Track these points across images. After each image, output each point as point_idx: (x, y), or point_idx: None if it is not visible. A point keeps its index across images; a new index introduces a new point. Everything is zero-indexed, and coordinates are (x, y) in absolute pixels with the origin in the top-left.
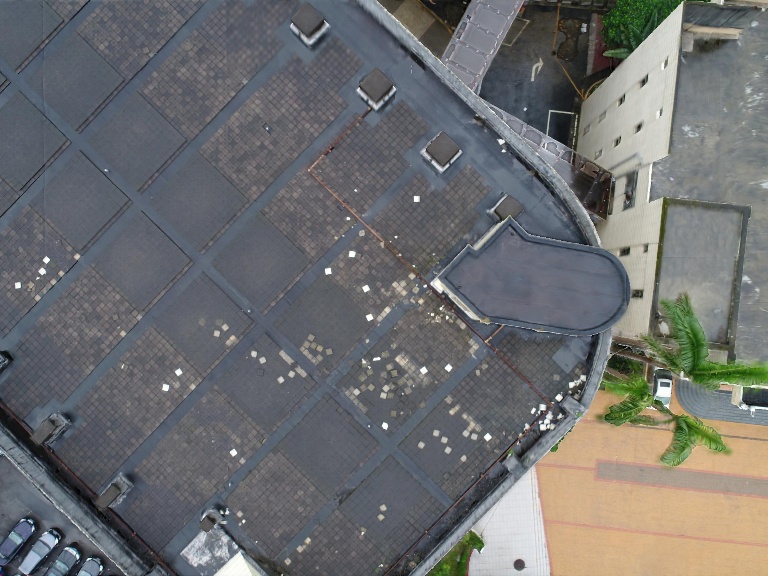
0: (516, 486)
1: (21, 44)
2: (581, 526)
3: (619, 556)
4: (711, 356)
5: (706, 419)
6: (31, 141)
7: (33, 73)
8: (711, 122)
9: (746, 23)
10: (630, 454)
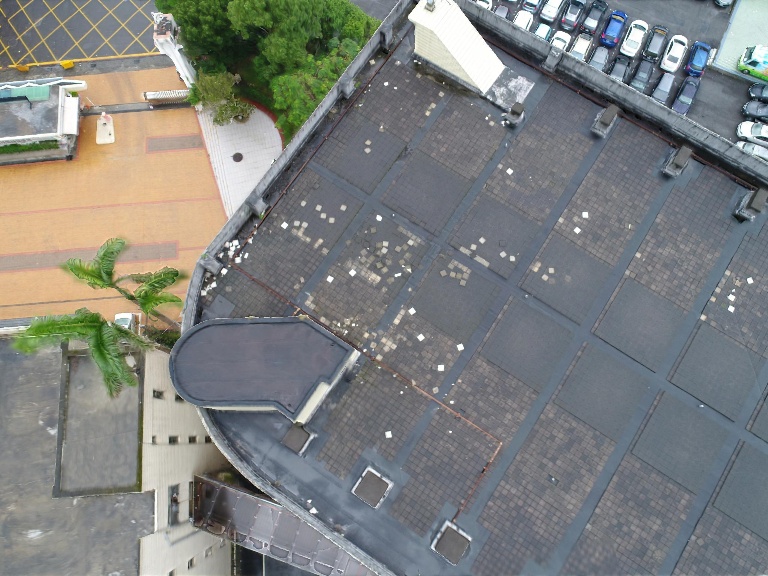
0: None
1: None
2: (187, 200)
3: (150, 181)
4: (83, 346)
5: None
6: None
7: None
8: None
9: None
10: (148, 269)
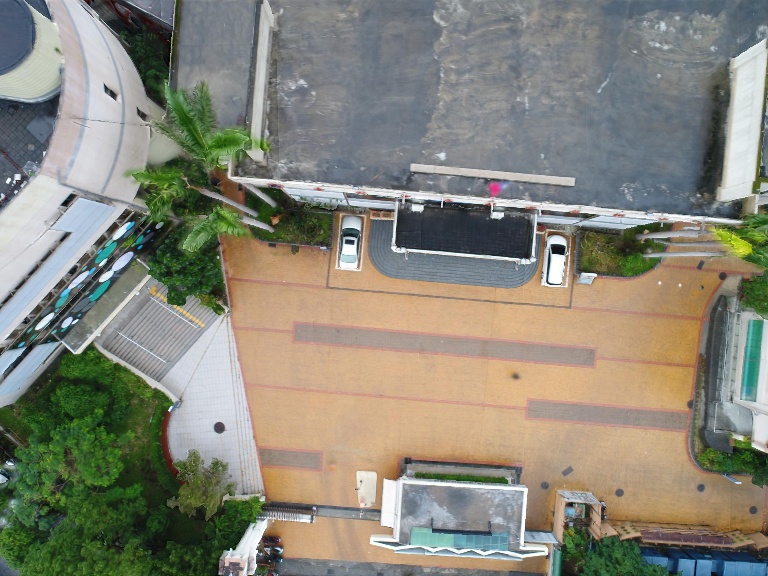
0: (213, 349)
1: None
2: (281, 389)
3: (320, 417)
4: None
5: (399, 279)
6: None
7: None
8: None
9: None
10: (326, 316)
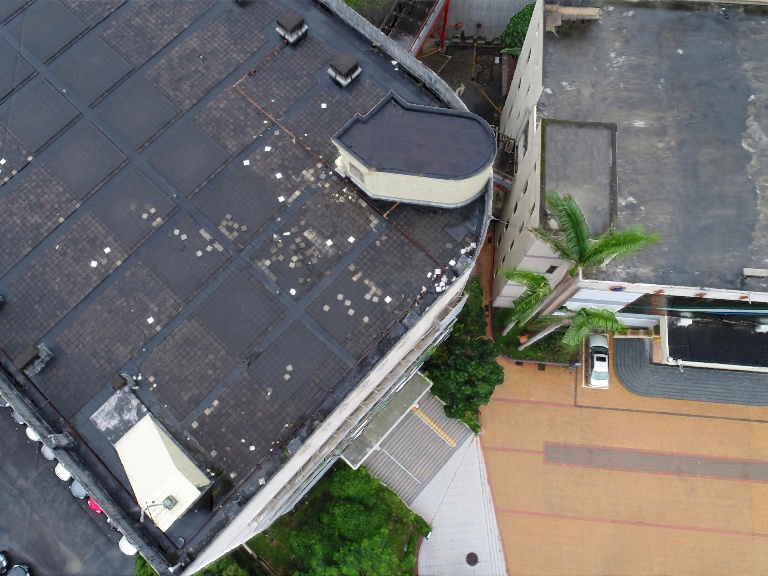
0: (464, 471)
1: (9, 5)
2: (534, 515)
3: (577, 548)
4: None
5: (648, 397)
6: (5, 72)
7: (15, 25)
8: (585, 78)
9: (600, 1)
10: (577, 435)
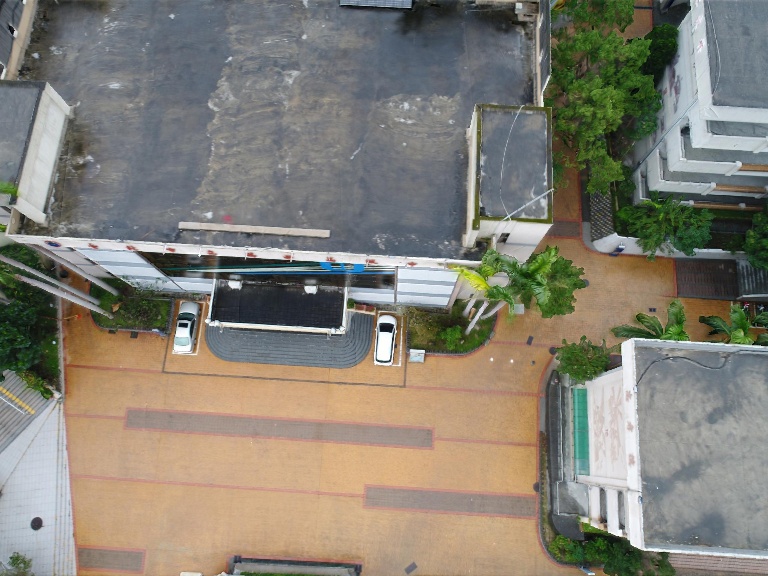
0: (41, 438)
1: None
2: (108, 479)
3: (145, 510)
4: None
5: (234, 362)
6: None
7: None
8: (73, 43)
9: None
10: (160, 400)
